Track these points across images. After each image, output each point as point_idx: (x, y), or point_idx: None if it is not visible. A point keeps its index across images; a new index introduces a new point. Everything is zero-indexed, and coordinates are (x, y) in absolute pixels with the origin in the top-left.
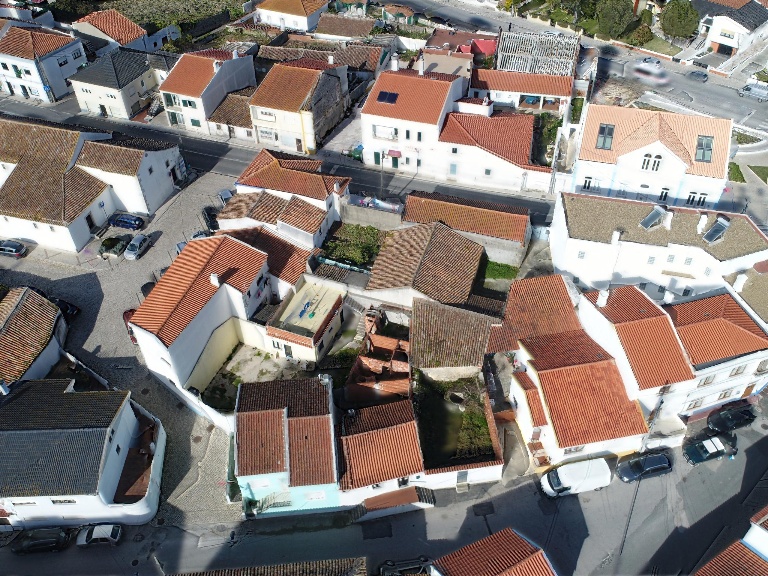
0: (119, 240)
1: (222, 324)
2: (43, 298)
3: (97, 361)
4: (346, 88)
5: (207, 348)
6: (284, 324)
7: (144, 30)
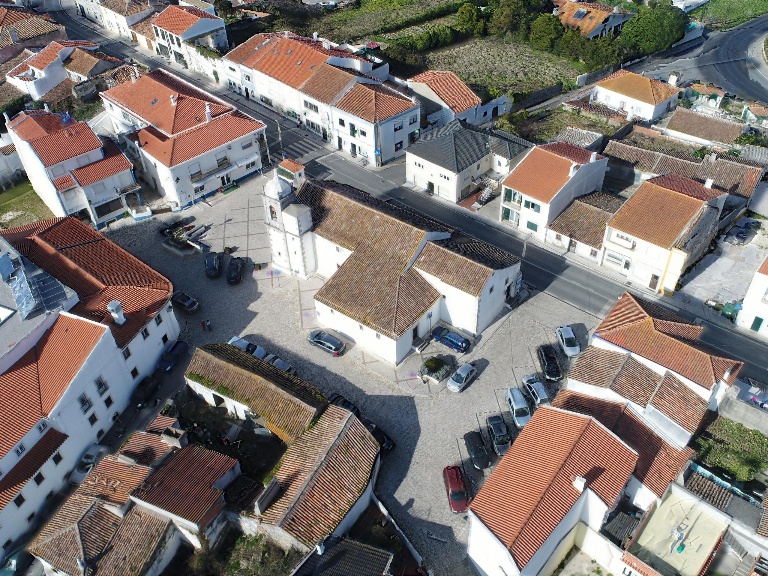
0: (443, 363)
1: (569, 531)
2: (365, 429)
3: (408, 520)
4: (717, 218)
5: (548, 560)
6: (644, 551)
7: (479, 99)
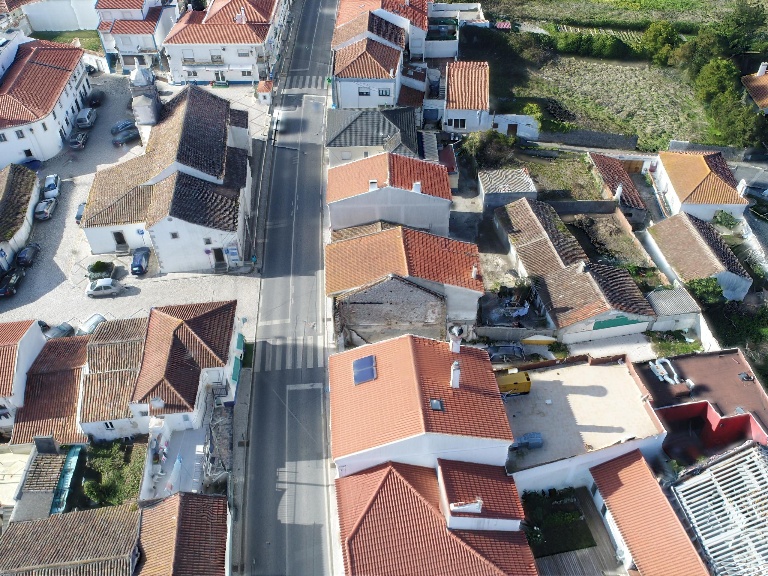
0: (106, 270)
1: None
2: None
3: None
4: (471, 316)
5: None
6: None
7: (488, 105)
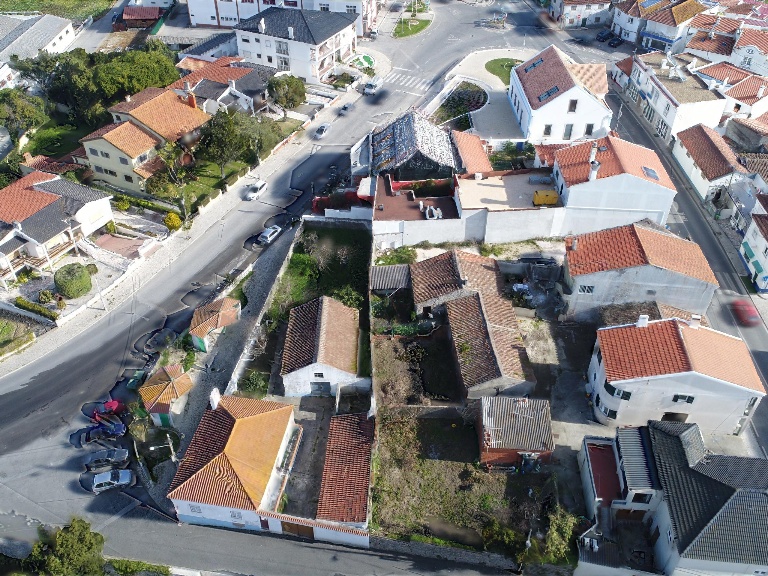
0: None
1: None
2: None
3: None
4: None
5: None
6: None
7: None
